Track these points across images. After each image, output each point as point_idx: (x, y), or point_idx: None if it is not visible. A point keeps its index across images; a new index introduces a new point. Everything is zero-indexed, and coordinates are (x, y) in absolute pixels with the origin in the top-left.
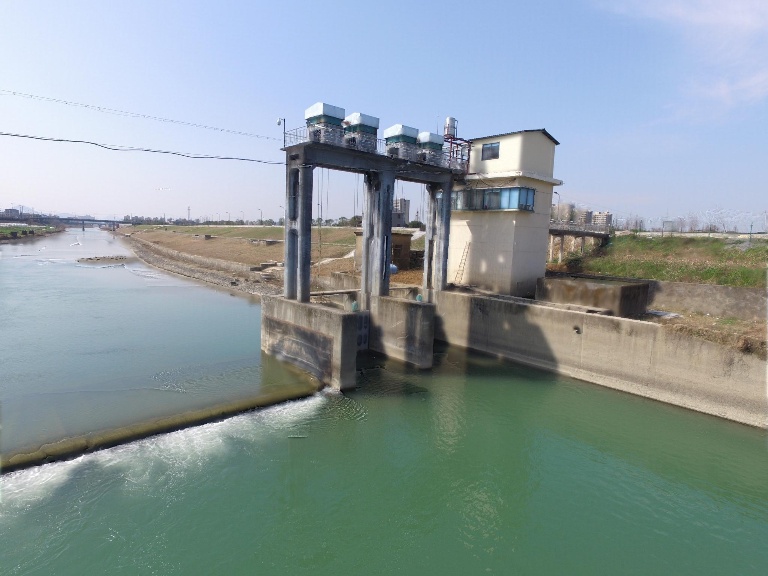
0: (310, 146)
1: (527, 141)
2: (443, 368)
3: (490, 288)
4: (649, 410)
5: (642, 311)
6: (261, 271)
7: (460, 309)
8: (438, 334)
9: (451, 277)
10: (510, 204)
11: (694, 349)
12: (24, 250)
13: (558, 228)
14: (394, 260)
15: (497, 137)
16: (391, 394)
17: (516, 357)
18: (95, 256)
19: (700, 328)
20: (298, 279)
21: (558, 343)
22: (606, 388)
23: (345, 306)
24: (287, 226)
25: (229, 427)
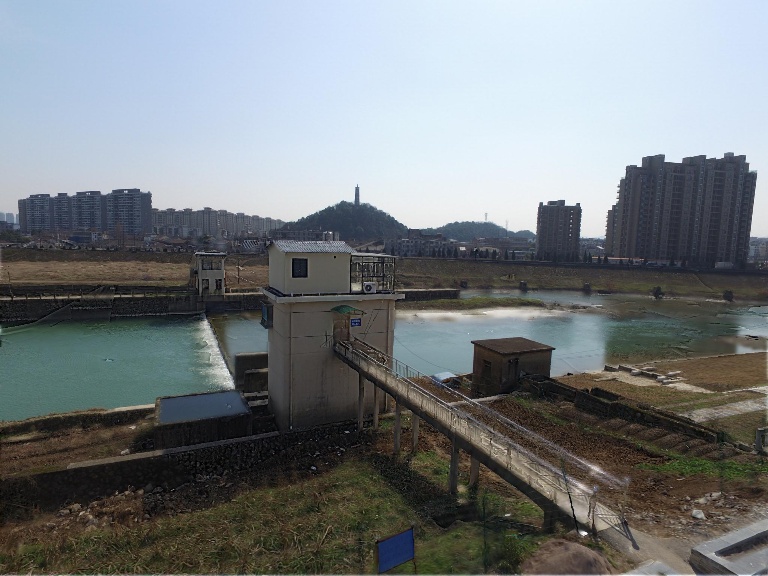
0: None
1: None
2: None
3: None
4: None
5: None
6: None
7: None
8: None
9: None
10: None
11: None
12: None
13: (389, 383)
14: (482, 378)
15: None
16: None
17: None
18: None
19: None
20: None
21: None
22: None
23: None
24: None
25: None
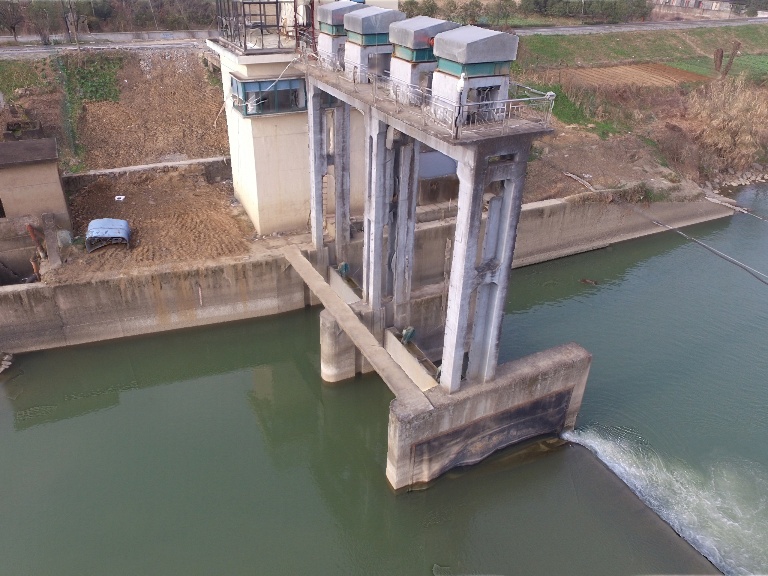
0: None
1: None
2: None
3: None
4: (569, 268)
5: None
6: None
7: (384, 255)
8: None
9: (301, 212)
10: None
11: (586, 211)
12: None
13: None
14: None
15: None
16: None
17: None
18: None
19: (589, 195)
20: (492, 352)
21: None
22: (531, 266)
23: (338, 343)
24: (470, 284)
25: (710, 541)
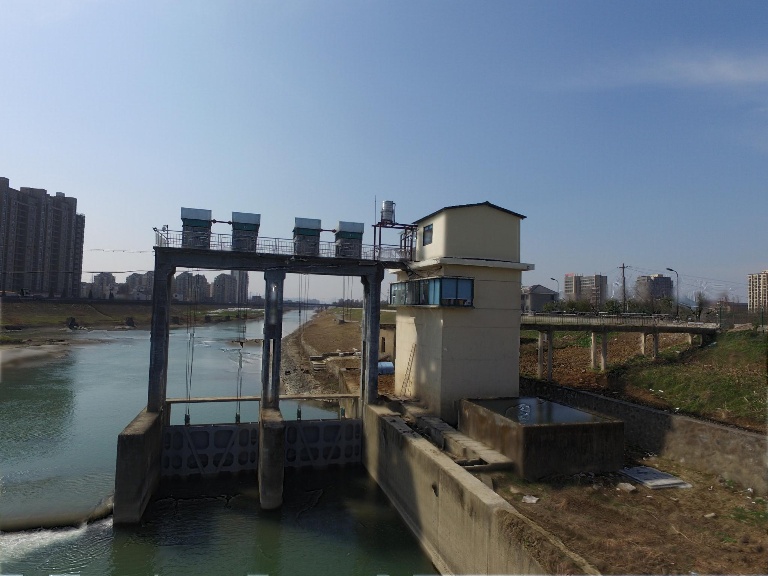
0: (160, 251)
1: (458, 219)
2: (290, 512)
3: (427, 405)
4: None
5: (609, 468)
6: (320, 361)
7: (374, 431)
8: (364, 459)
9: None
10: (435, 299)
11: (523, 570)
12: (211, 332)
13: (592, 323)
14: None
15: (430, 218)
16: (178, 539)
17: (401, 512)
18: (246, 339)
19: (530, 531)
20: None
21: (424, 504)
22: None
23: None
24: None
25: None
